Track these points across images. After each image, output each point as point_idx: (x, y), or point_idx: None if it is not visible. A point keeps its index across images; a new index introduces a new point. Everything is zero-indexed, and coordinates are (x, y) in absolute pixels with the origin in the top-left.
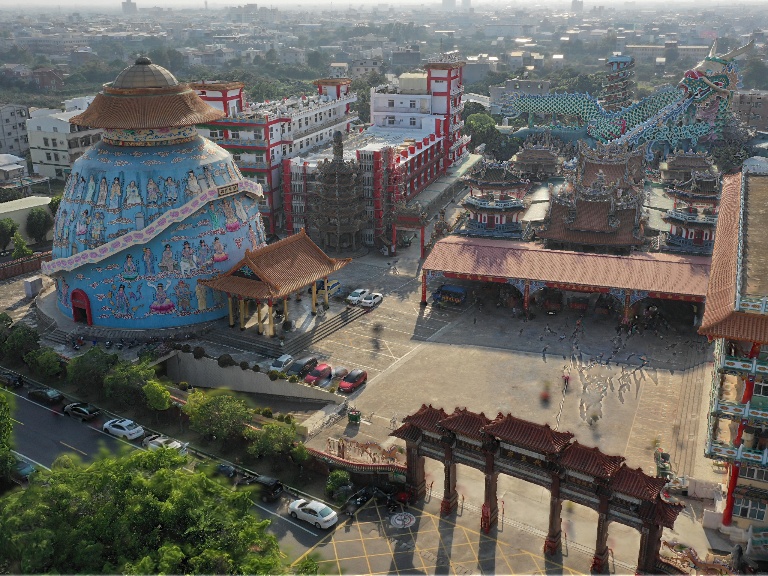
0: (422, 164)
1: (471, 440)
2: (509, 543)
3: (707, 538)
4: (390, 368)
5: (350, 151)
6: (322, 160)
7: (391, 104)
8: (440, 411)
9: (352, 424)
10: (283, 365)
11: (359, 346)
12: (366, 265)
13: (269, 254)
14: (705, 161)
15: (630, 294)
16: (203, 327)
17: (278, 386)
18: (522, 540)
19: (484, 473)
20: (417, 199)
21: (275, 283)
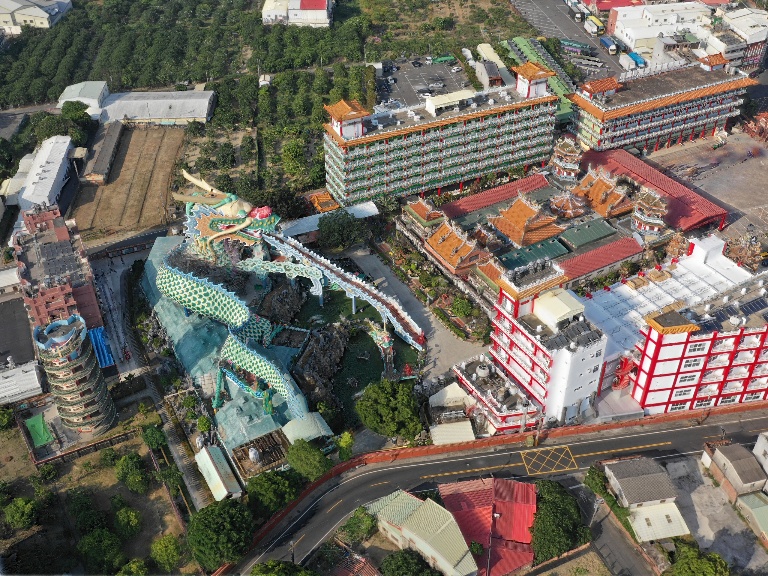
0: None
1: None
2: None
3: None
4: None
5: (696, 296)
6: None
7: None
8: None
9: None
10: None
11: None
12: None
13: None
14: None
15: None
16: None
17: None
18: None
19: None
20: None
21: None
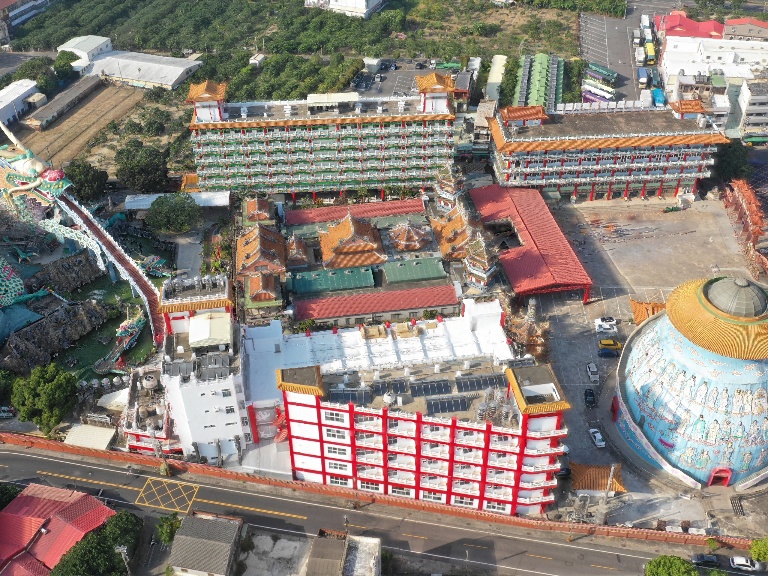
0: None
1: None
2: None
3: None
4: None
5: None
6: None
7: None
8: None
9: None
10: None
11: None
12: None
13: None
14: None
15: None
16: None
17: None
18: None
19: None
20: None
21: None
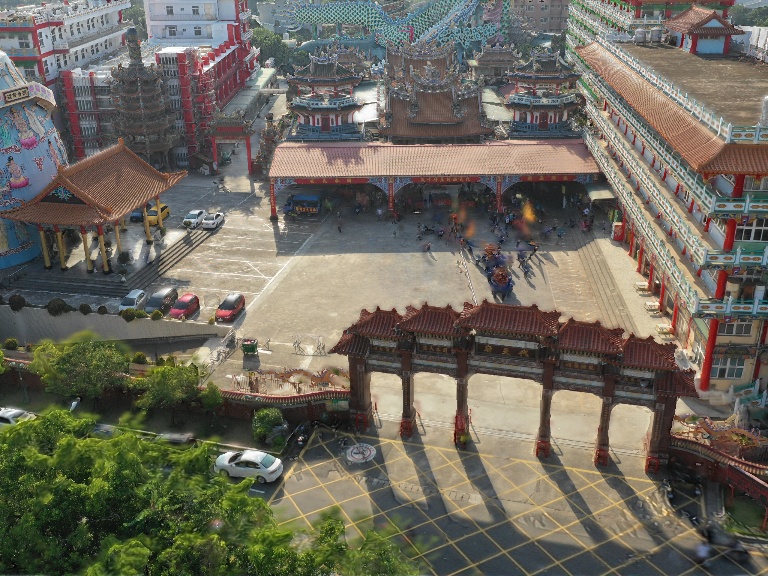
0: (221, 75)
1: (436, 341)
2: (494, 454)
3: (689, 407)
4: (266, 289)
5: None
6: (109, 71)
7: (170, 11)
8: (392, 312)
9: (249, 356)
10: (136, 302)
11: (219, 271)
12: (188, 187)
13: (87, 171)
14: (513, 55)
15: (501, 180)
16: (10, 273)
17: (136, 328)
18: (506, 448)
19: (454, 378)
20: (225, 113)
21: (103, 205)
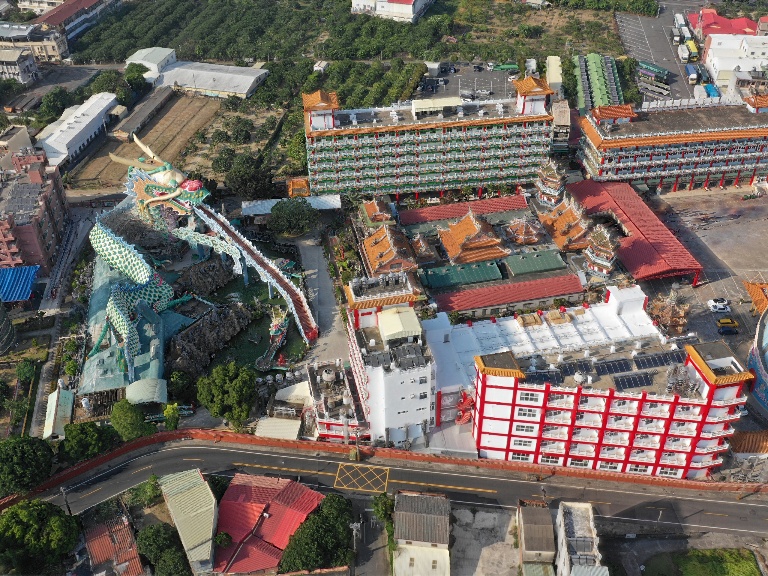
0: None
1: None
2: None
3: None
4: None
5: None
6: None
7: None
8: None
9: None
10: None
11: None
12: None
13: None
14: None
15: None
16: None
17: None
18: None
19: None
20: None
21: None
